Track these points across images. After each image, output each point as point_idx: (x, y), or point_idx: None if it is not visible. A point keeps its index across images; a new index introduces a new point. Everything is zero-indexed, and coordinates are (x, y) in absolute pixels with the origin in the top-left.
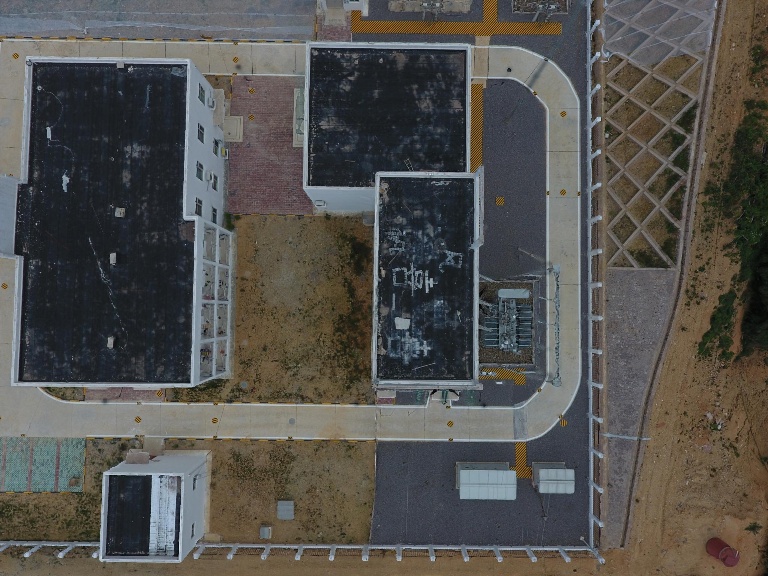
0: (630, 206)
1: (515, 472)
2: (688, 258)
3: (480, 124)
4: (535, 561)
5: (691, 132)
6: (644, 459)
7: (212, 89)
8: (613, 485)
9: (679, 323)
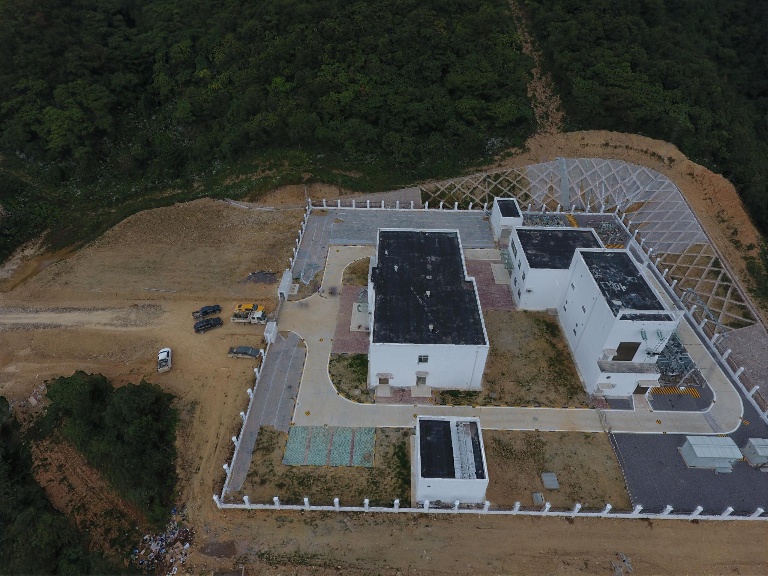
0: (709, 305)
1: (730, 438)
2: (763, 320)
3: None
4: None
5: (722, 268)
6: None
7: None
8: None
9: None
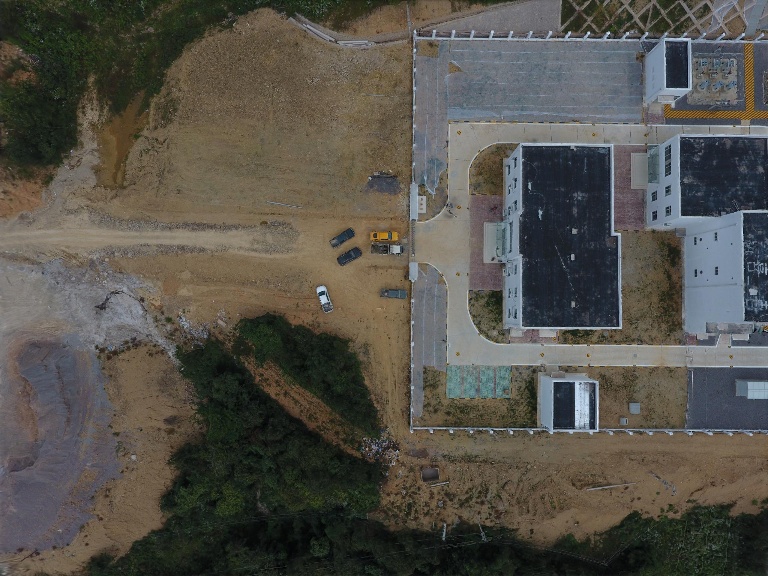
0: None
1: None
2: None
3: None
4: None
5: None
6: None
7: None
8: None
9: None
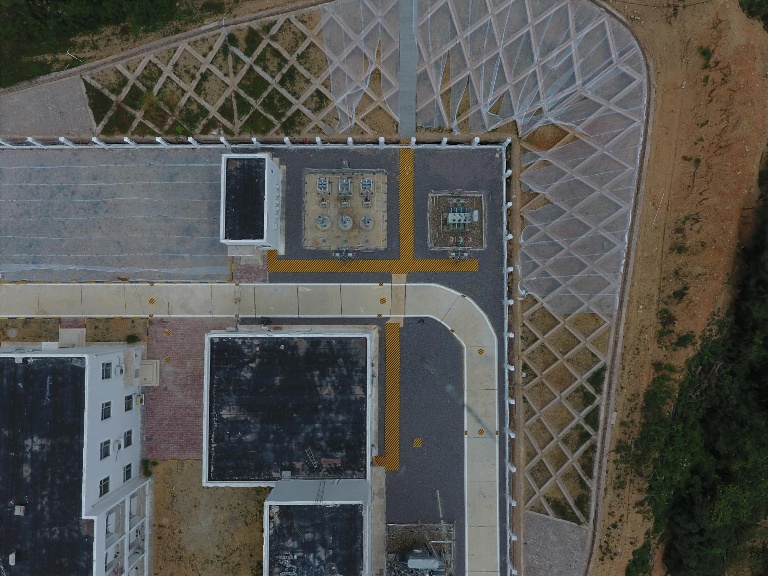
0: (546, 452)
1: None
2: (600, 515)
3: (397, 364)
4: None
5: (600, 393)
6: None
7: (121, 352)
8: None
9: None
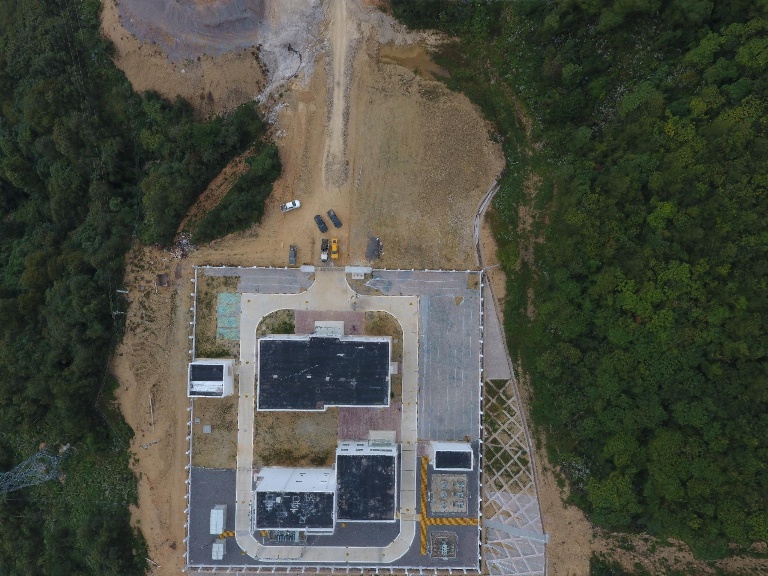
0: None
1: None
2: None
3: None
4: (184, 542)
5: None
6: None
7: None
8: (215, 575)
9: None
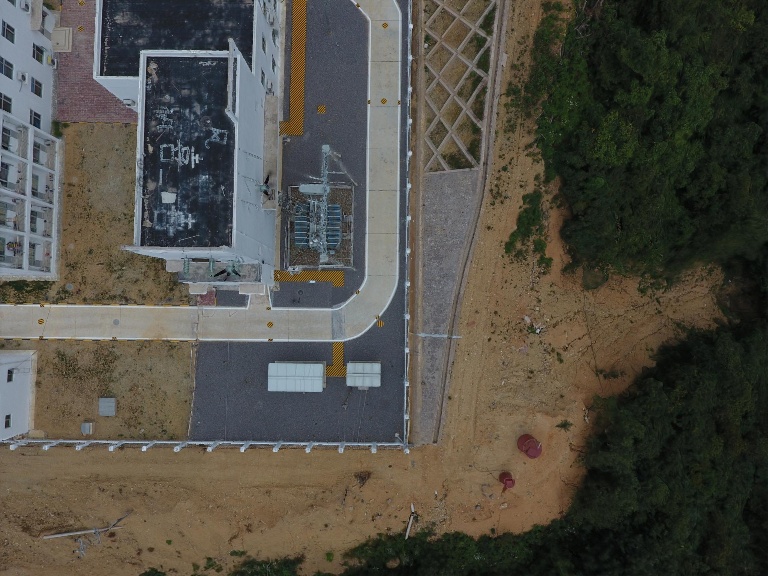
0: (443, 112)
1: (322, 365)
2: (491, 158)
3: (303, 35)
4: (341, 451)
5: (491, 34)
6: (455, 357)
7: None
8: (426, 383)
9: (485, 222)
